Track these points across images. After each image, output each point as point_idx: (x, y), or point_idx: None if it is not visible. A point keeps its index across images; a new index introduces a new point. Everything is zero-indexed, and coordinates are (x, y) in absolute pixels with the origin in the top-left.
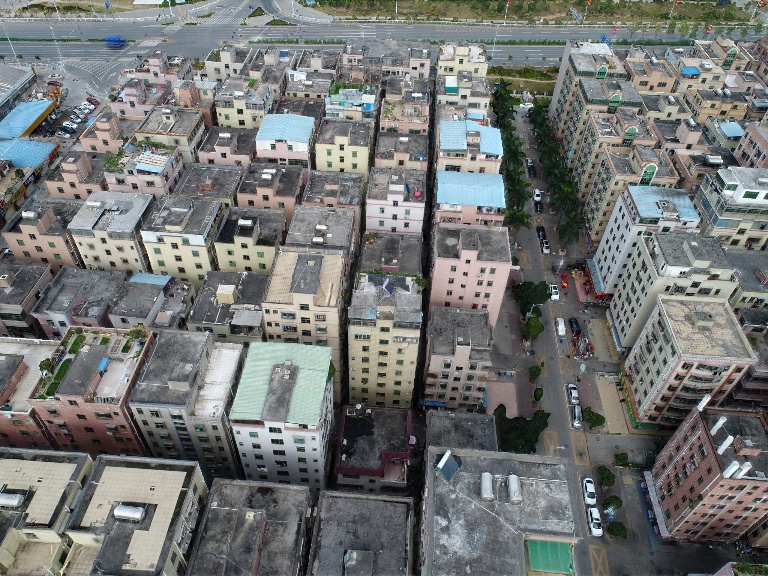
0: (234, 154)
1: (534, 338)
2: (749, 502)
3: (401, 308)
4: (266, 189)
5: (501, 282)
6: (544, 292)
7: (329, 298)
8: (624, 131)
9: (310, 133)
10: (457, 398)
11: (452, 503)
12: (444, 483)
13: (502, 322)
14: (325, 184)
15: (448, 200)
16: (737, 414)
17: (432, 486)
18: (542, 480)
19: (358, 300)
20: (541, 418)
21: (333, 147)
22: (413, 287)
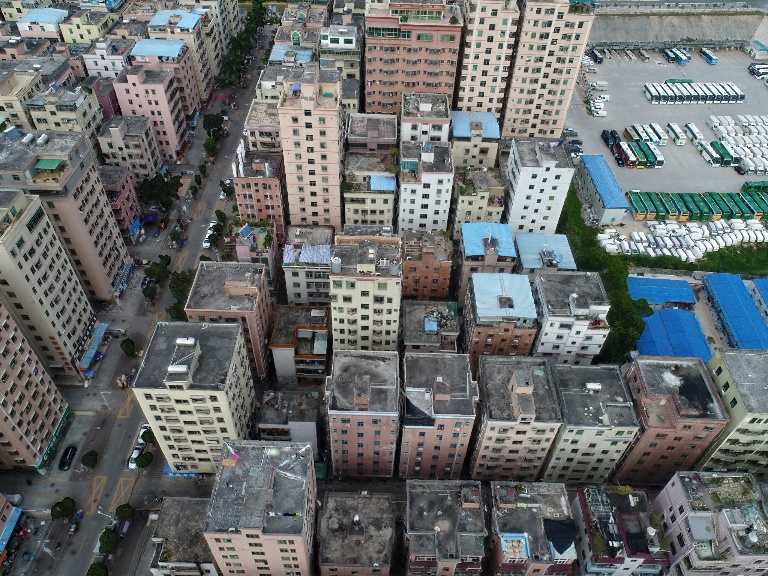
0: (5, 35)
1: (211, 152)
2: (264, 200)
3: (63, 100)
4: (11, 49)
5: (163, 101)
6: (217, 120)
7: (16, 94)
8: (297, 16)
9: (59, 19)
10: (133, 177)
11: (7, 147)
12: (8, 141)
13: (200, 148)
14: (55, 46)
15: (138, 53)
16: (267, 154)
17: (1, 142)
18: (64, 140)
19: (37, 97)
20: (173, 178)
21: (72, 27)
22: (82, 93)
